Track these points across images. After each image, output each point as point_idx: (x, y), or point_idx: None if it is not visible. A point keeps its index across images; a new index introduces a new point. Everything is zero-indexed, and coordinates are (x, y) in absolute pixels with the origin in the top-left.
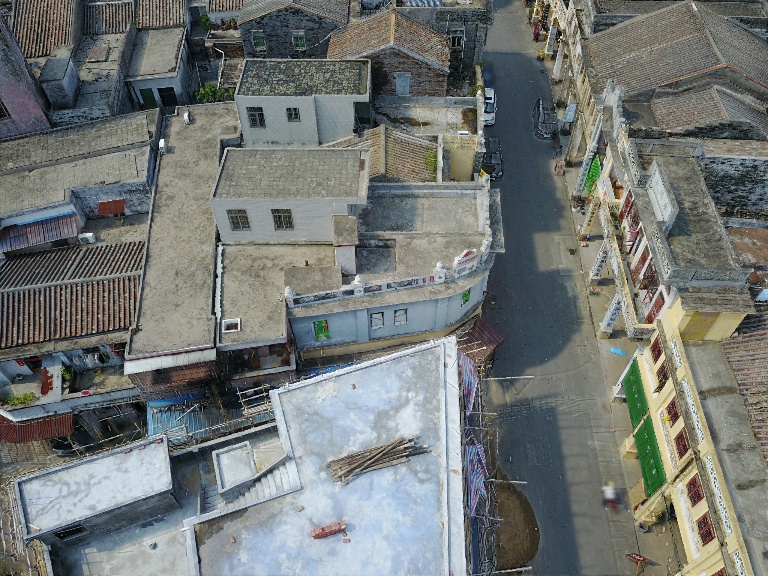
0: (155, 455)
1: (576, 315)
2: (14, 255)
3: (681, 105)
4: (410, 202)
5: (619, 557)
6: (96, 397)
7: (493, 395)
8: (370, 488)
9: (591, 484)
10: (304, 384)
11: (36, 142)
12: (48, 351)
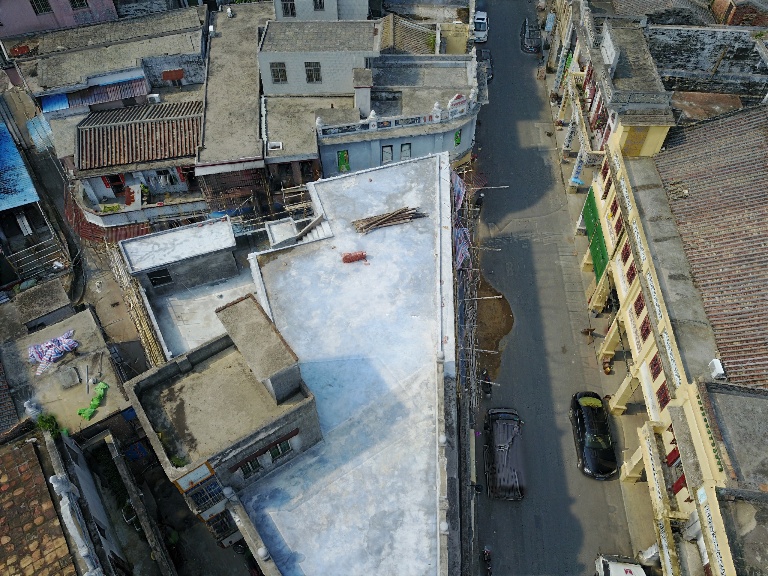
0: (221, 228)
1: (550, 178)
2: (96, 110)
3: (637, 1)
4: (413, 70)
5: (575, 333)
6: (168, 209)
7: (480, 231)
8: (383, 236)
9: (556, 288)
10: (333, 178)
11: (109, 27)
12: (132, 170)
